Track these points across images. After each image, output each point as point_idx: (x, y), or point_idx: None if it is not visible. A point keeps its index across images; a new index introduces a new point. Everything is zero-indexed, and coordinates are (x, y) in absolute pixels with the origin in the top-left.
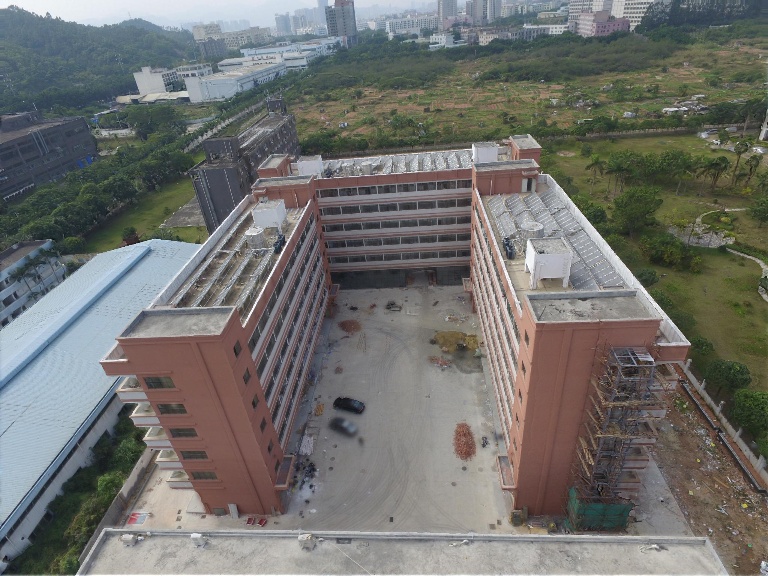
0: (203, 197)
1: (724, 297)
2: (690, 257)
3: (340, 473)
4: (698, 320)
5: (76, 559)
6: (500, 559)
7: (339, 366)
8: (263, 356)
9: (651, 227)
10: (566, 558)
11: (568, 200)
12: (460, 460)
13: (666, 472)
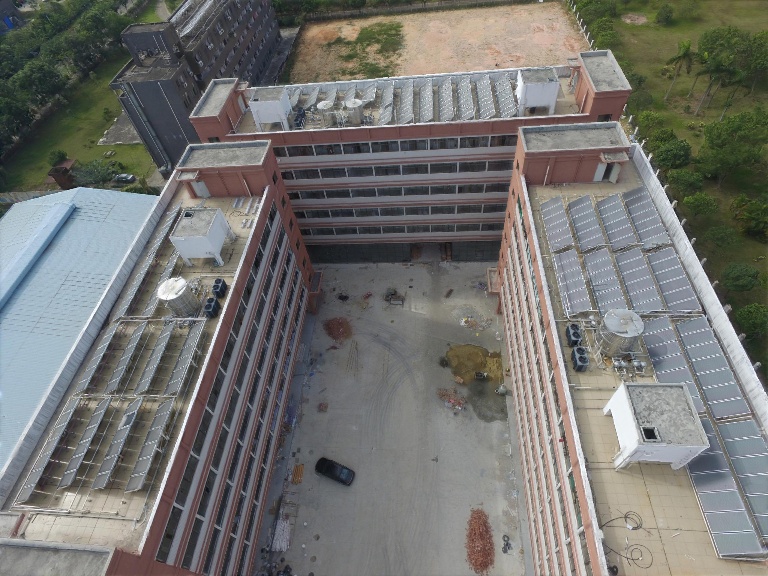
0: (138, 119)
1: None
2: None
3: None
4: None
5: None
6: None
7: (323, 399)
8: (193, 526)
9: None
10: None
11: (674, 221)
12: (474, 574)
13: None
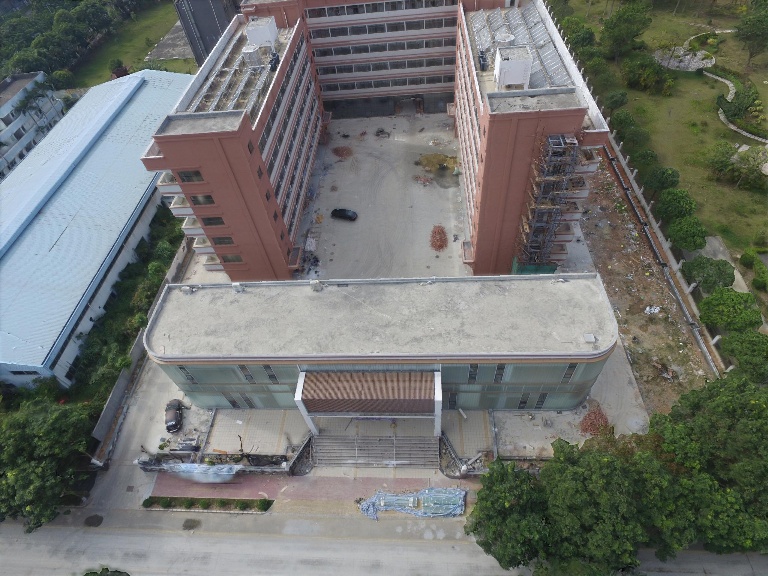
0: (187, 23)
1: (685, 118)
2: (665, 80)
3: (338, 263)
4: (655, 139)
5: (145, 316)
6: (453, 291)
7: (334, 185)
8: (270, 160)
9: (638, 51)
10: (499, 289)
11: (546, 14)
12: (434, 251)
13: (595, 254)
